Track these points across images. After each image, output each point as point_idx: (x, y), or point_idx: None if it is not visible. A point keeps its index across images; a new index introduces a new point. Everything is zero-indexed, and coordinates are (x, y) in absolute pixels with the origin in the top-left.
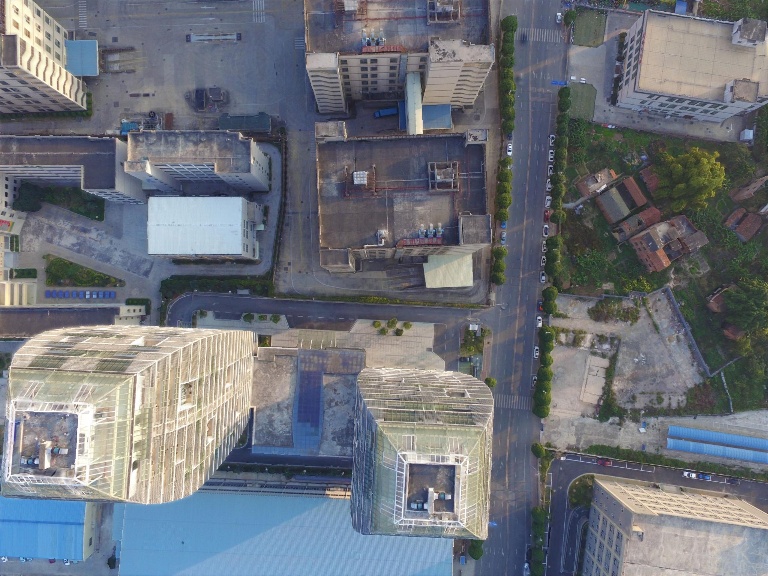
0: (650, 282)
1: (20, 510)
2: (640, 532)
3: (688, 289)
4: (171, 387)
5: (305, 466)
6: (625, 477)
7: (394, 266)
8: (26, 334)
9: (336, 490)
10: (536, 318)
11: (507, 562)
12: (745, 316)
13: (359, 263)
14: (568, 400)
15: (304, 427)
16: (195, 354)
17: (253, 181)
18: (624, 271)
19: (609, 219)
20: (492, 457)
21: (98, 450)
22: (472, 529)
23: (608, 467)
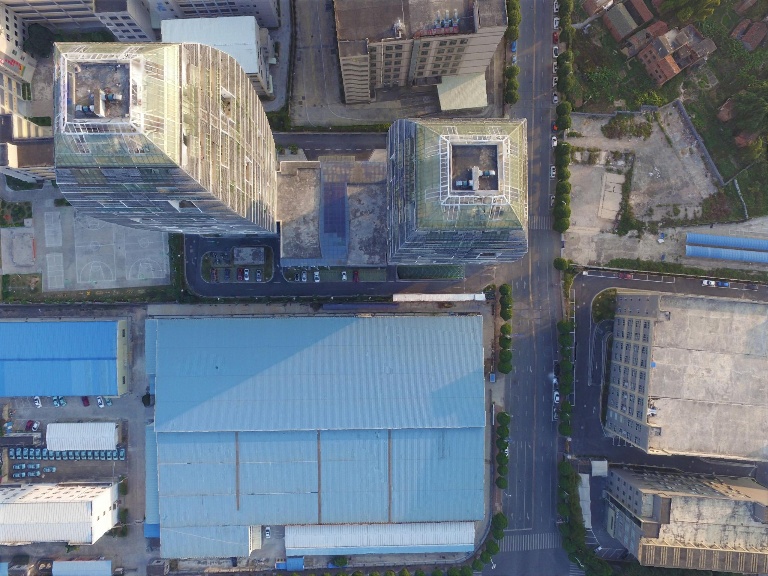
0: (661, 97)
1: (52, 349)
2: (667, 312)
3: (698, 102)
4: (213, 83)
5: (332, 296)
6: (646, 289)
7: (408, 95)
8: (47, 165)
9: (364, 315)
10: (551, 139)
11: (536, 379)
12: (756, 115)
13: (373, 90)
14: (587, 217)
15: (331, 237)
16: (232, 69)
17: (264, 3)
18: (635, 88)
19: (617, 36)
20: (515, 277)
21: (150, 102)
22: (516, 212)
23: (629, 280)
